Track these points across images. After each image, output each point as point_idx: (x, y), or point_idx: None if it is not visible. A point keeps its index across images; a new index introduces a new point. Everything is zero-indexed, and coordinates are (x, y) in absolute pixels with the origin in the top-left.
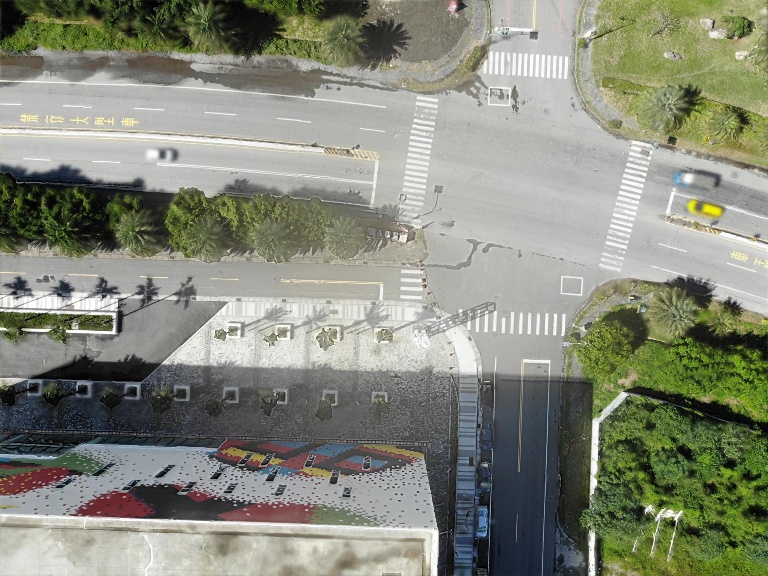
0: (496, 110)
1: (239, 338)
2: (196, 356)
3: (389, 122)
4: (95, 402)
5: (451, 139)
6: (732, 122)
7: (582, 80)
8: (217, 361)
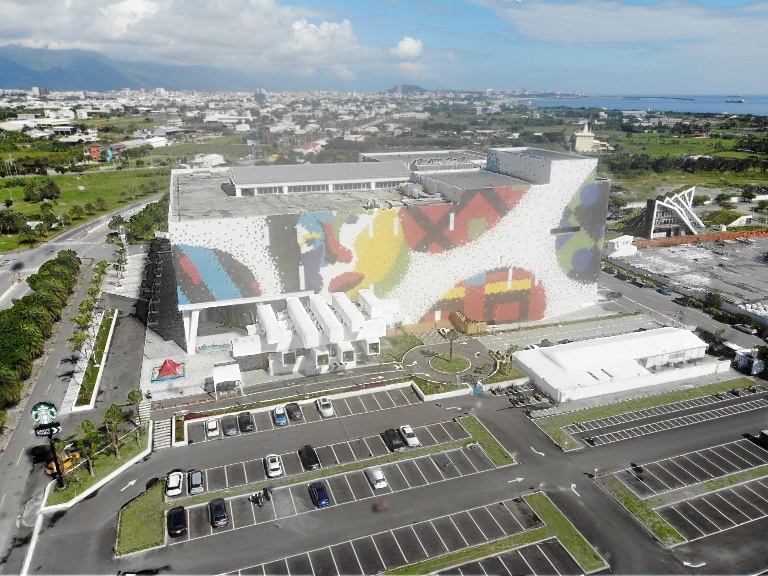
0: (13, 262)
1: (124, 286)
2: (134, 293)
3: (8, 276)
4: (163, 309)
5: (25, 266)
6: (40, 223)
7: (7, 253)
8: (138, 289)
